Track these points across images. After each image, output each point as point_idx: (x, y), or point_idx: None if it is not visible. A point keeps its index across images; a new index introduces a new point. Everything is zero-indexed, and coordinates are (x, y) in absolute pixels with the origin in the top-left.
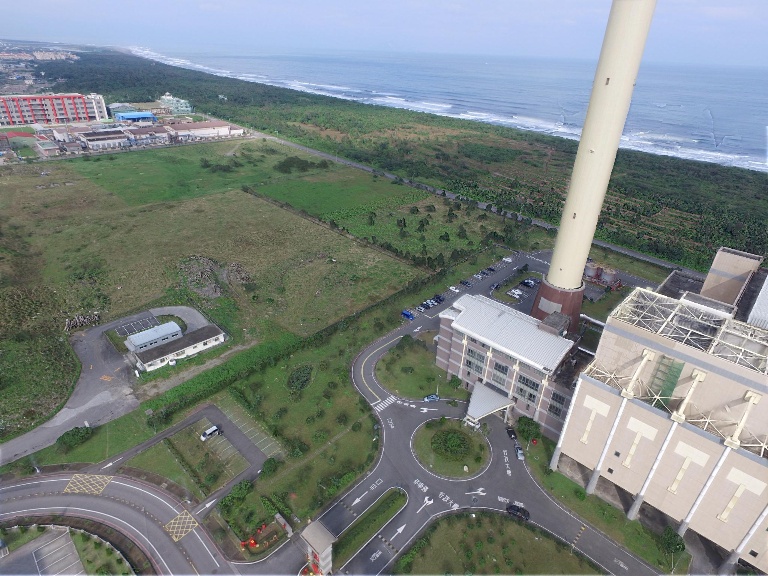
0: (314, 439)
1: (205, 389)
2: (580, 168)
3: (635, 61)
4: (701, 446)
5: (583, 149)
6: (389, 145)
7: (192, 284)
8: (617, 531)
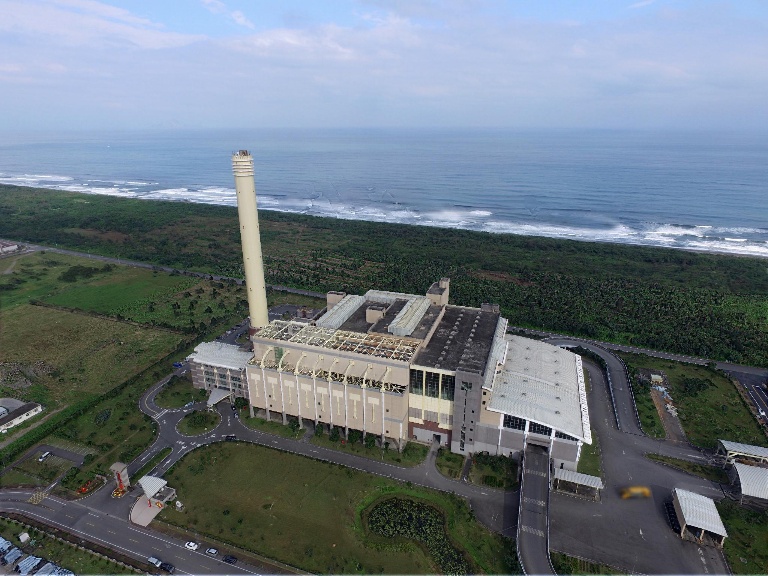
0: (115, 440)
1: (35, 437)
2: (246, 266)
3: (252, 218)
4: (290, 379)
5: (244, 257)
6: (169, 241)
7: (4, 383)
8: (277, 431)
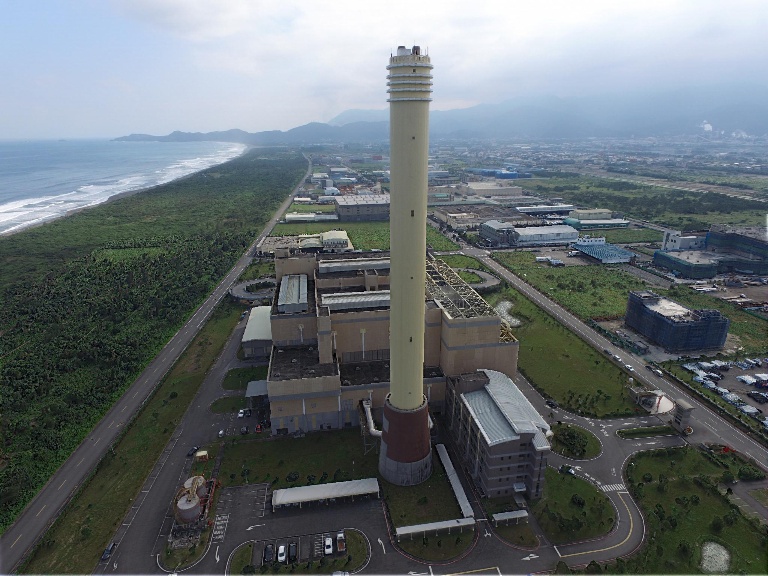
0: None
1: None
2: None
3: None
4: None
5: None
6: None
7: None
8: None
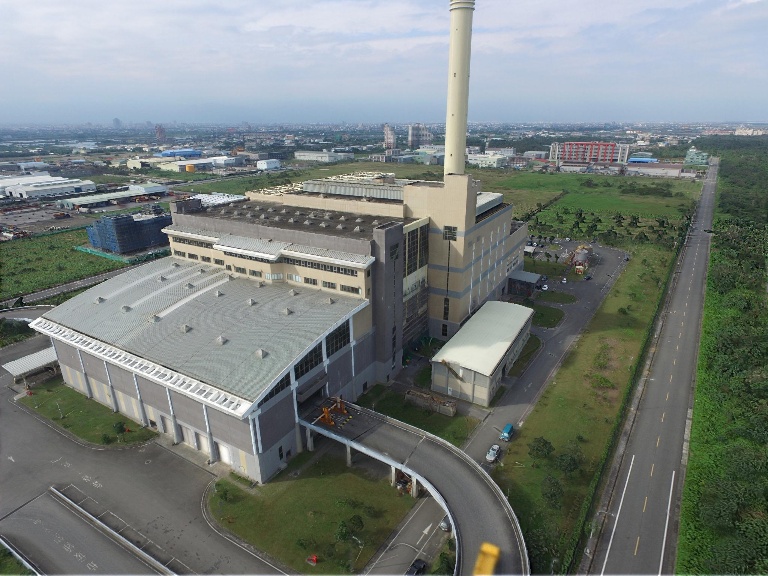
0: None
1: None
2: None
3: (451, 64)
4: None
5: None
6: None
7: None
8: None
